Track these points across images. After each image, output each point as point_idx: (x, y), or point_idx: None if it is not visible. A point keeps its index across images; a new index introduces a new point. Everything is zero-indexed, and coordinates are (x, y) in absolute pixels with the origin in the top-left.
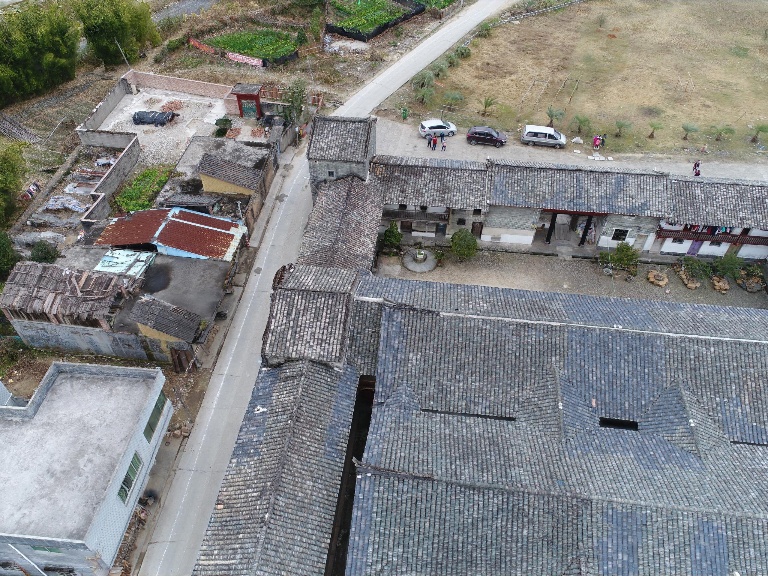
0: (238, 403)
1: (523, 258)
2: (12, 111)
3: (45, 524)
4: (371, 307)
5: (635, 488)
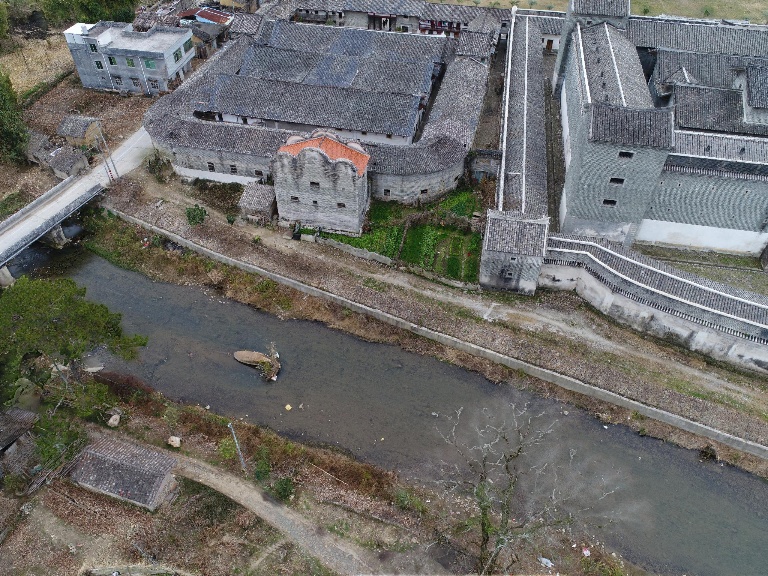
0: None
1: None
2: None
3: None
4: (272, 23)
5: None
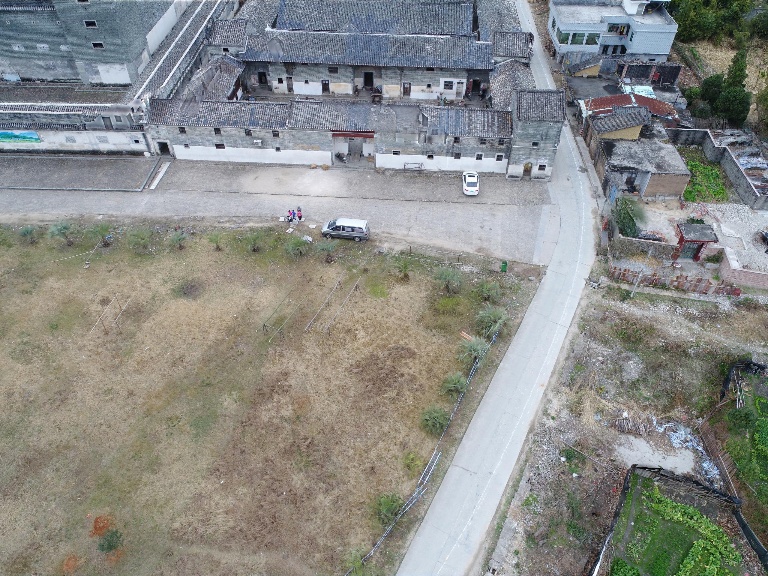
0: None
1: (389, 138)
2: None
3: (568, 7)
4: None
5: (380, 7)
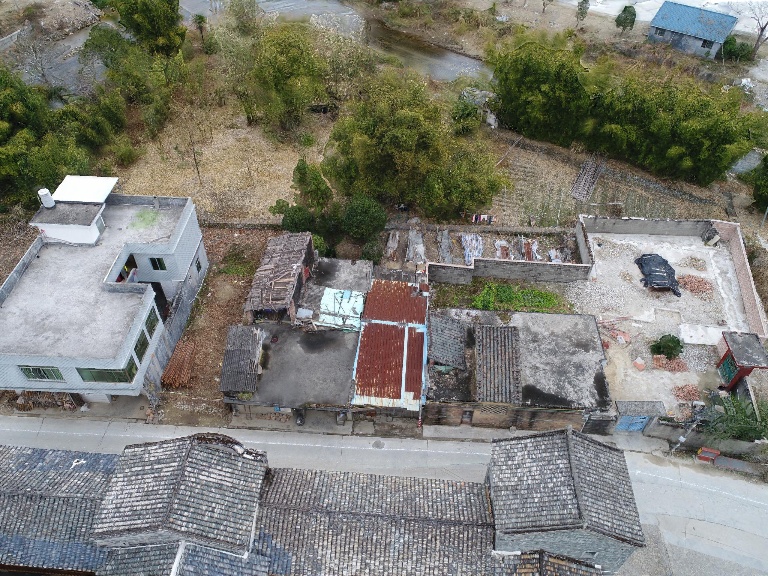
0: None
1: None
2: (613, 166)
3: None
4: (167, 569)
5: None
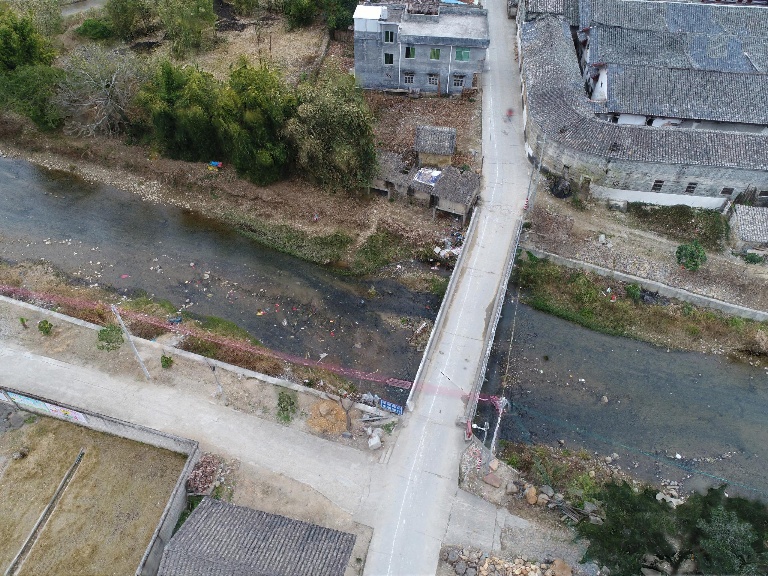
0: (500, 55)
1: None
2: None
3: None
4: None
5: None
